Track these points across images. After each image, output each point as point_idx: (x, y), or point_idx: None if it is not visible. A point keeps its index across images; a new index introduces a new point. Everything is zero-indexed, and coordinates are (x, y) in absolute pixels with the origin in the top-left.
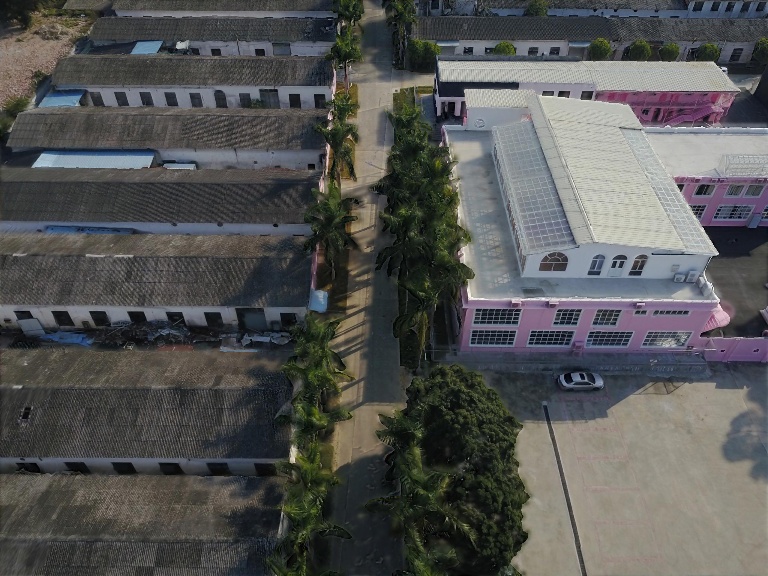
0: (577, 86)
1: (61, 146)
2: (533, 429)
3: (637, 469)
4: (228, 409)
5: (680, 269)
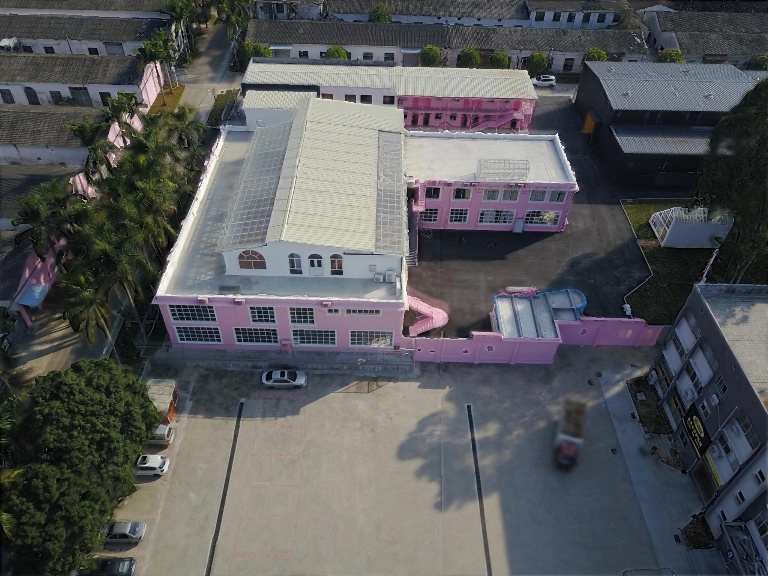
0: (377, 90)
1: None
2: (220, 425)
3: (305, 466)
4: None
5: (379, 269)
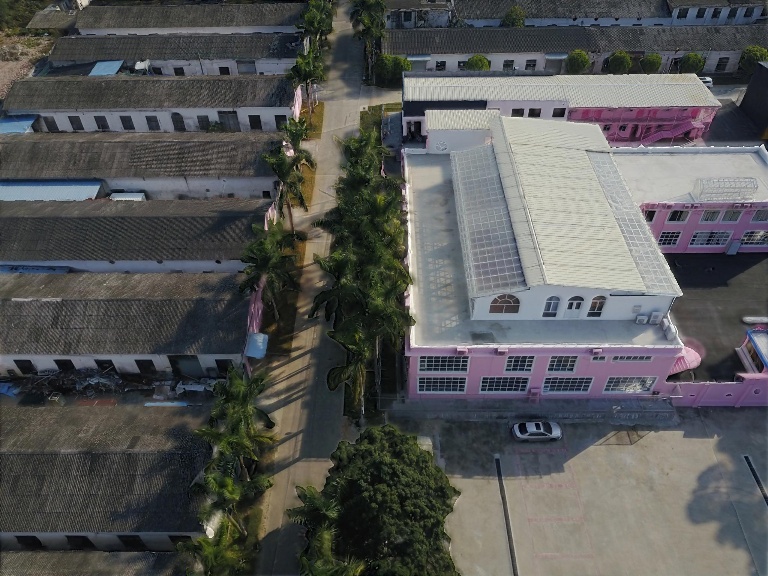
0: (548, 103)
1: (4, 177)
2: (482, 486)
3: (593, 533)
4: (141, 476)
5: (642, 310)
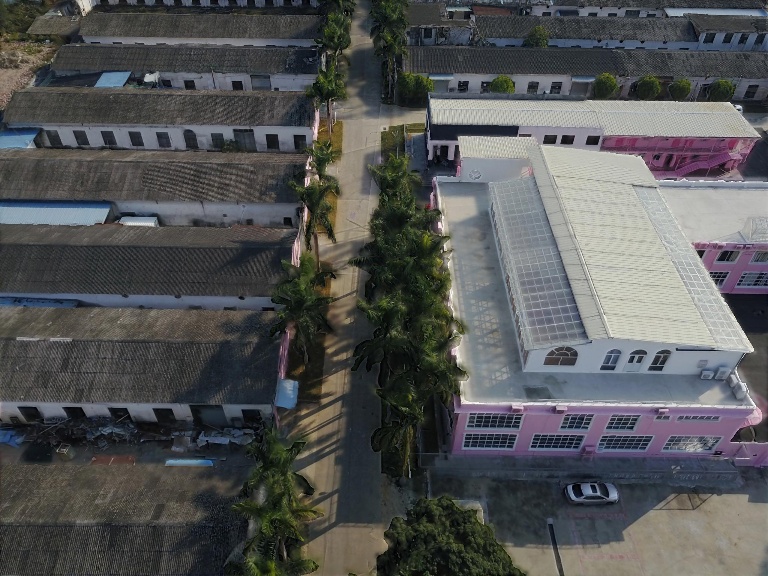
0: (582, 130)
1: (5, 197)
2: (537, 556)
3: None
4: (168, 552)
5: (708, 365)
